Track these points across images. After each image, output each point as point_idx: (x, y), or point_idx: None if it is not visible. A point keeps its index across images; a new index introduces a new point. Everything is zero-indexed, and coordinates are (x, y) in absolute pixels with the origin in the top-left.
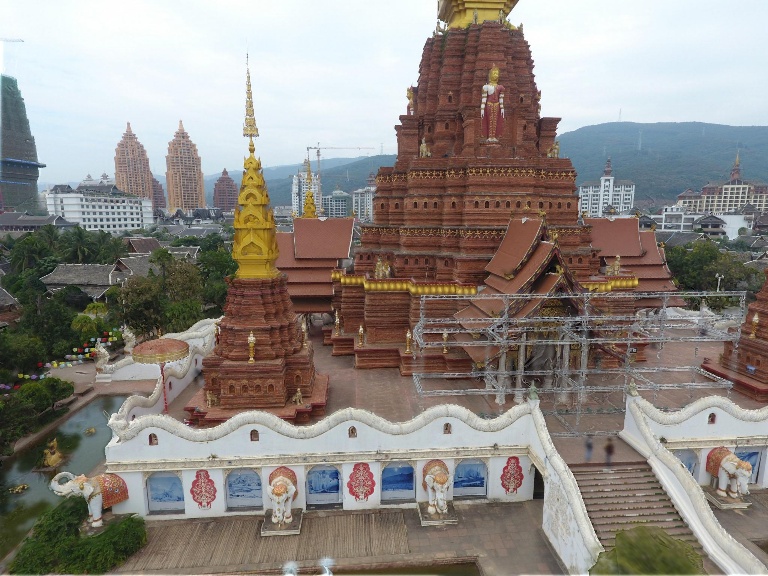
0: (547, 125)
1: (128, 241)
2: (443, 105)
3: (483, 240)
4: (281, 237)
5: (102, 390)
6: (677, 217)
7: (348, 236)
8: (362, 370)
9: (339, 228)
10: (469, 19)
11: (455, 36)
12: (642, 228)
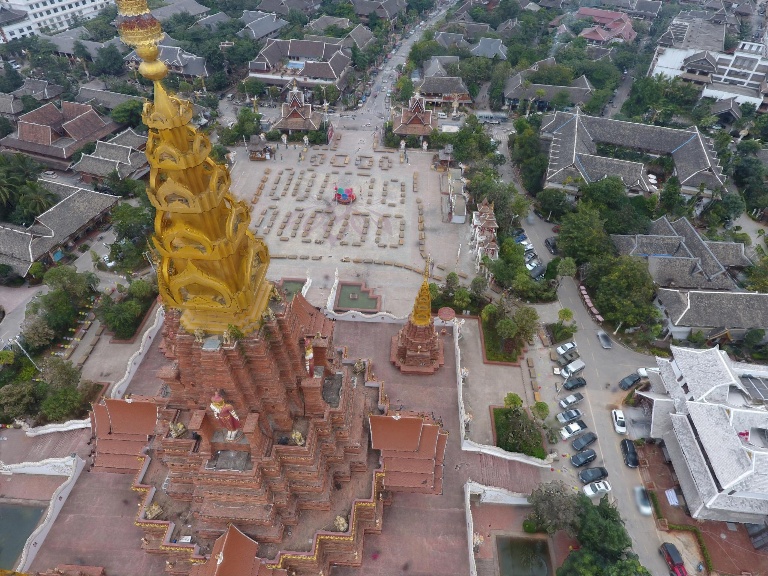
0: (307, 388)
1: (61, 127)
2: (188, 389)
3: (217, 518)
4: (99, 409)
5: (4, 490)
6: (752, 60)
7: (154, 415)
8: (150, 555)
9: (145, 409)
10: (198, 321)
11: (184, 340)
12: (695, 75)
